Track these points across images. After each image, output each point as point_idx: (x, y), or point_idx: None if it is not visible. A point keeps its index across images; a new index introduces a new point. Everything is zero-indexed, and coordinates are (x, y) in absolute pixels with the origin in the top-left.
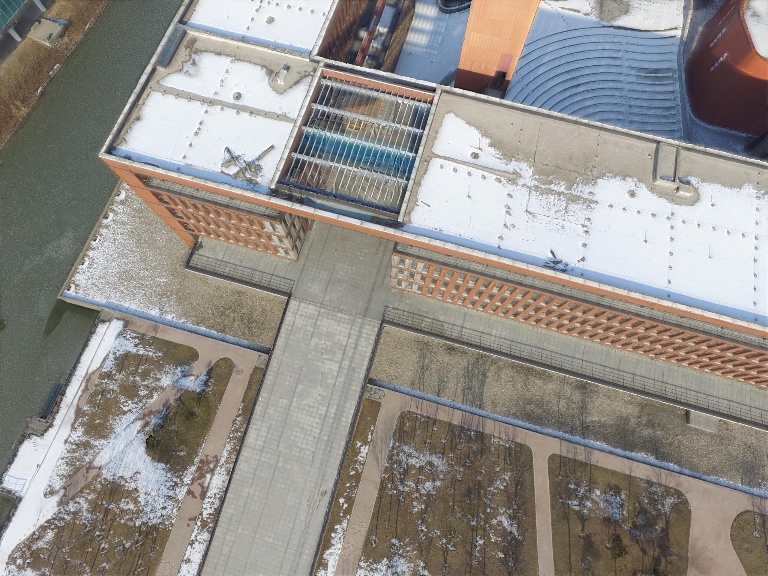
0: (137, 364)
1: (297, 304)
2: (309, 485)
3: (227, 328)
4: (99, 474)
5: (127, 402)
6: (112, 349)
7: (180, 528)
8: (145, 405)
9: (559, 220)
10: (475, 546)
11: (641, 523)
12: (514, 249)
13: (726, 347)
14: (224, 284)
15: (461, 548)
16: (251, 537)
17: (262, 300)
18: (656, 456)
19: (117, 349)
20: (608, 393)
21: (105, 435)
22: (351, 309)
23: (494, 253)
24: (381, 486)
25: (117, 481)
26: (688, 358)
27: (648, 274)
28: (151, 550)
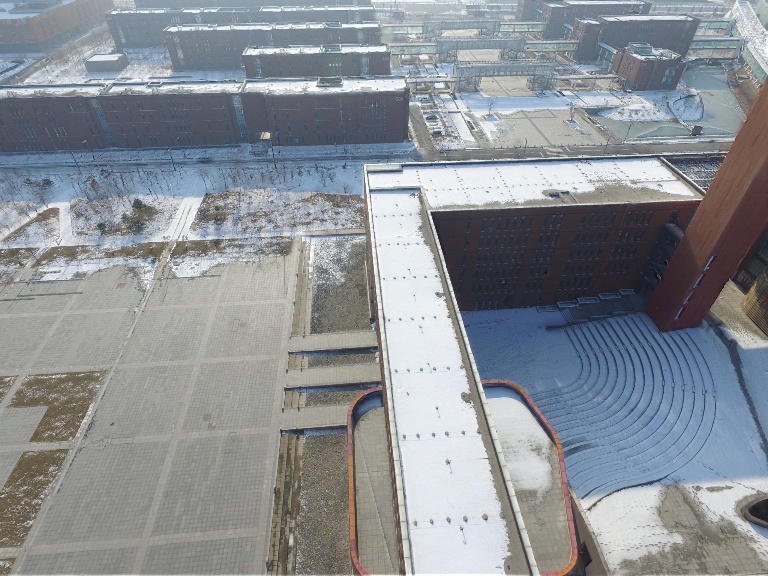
0: None
1: None
2: None
3: None
4: None
5: None
6: None
7: None
8: None
9: None
10: None
11: None
12: None
13: None
14: None
15: None
16: None
17: None
18: None
19: None
20: None
21: None
22: None
23: None
24: None
25: None
26: None
27: None
28: None
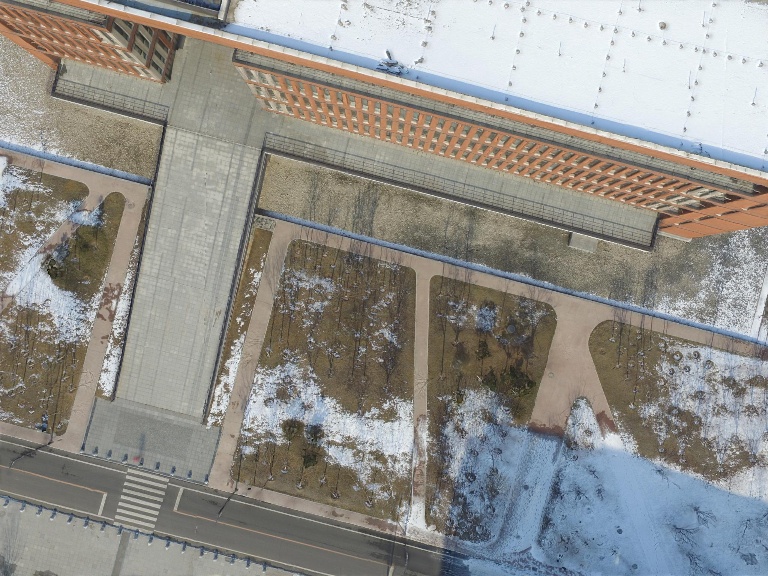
0: (29, 200)
1: (174, 133)
2: (204, 306)
3: (114, 162)
4: (13, 302)
5: (26, 237)
6: (1, 186)
7: (95, 345)
8: (44, 239)
9: (400, 14)
10: (358, 354)
11: (510, 332)
12: (347, 50)
13: (581, 159)
14: (105, 115)
15: (345, 355)
16: (158, 350)
17: (147, 132)
18: (533, 275)
19: (6, 186)
20: (496, 218)
21: (11, 268)
22: (230, 137)
23: (324, 55)
24: (274, 307)
25: (31, 307)
26: (557, 176)
27: (489, 76)
28: (72, 363)
